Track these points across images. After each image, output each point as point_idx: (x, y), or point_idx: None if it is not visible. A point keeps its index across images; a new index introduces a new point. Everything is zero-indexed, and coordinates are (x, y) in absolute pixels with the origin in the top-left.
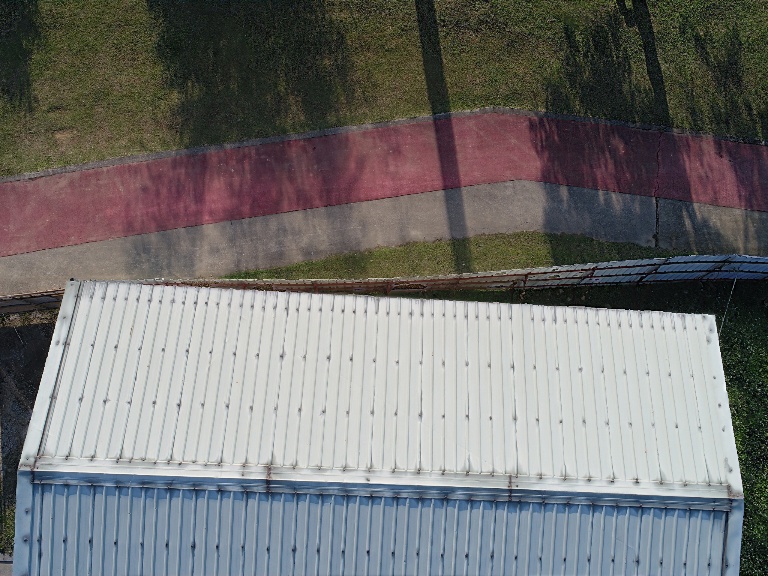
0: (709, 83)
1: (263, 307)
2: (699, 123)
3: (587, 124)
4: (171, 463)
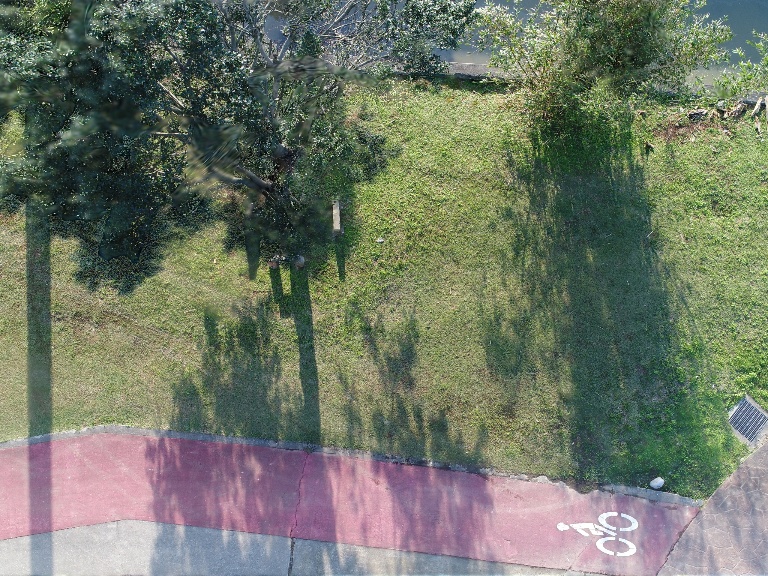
0: (374, 387)
1: None
2: (356, 439)
3: (218, 444)
4: None
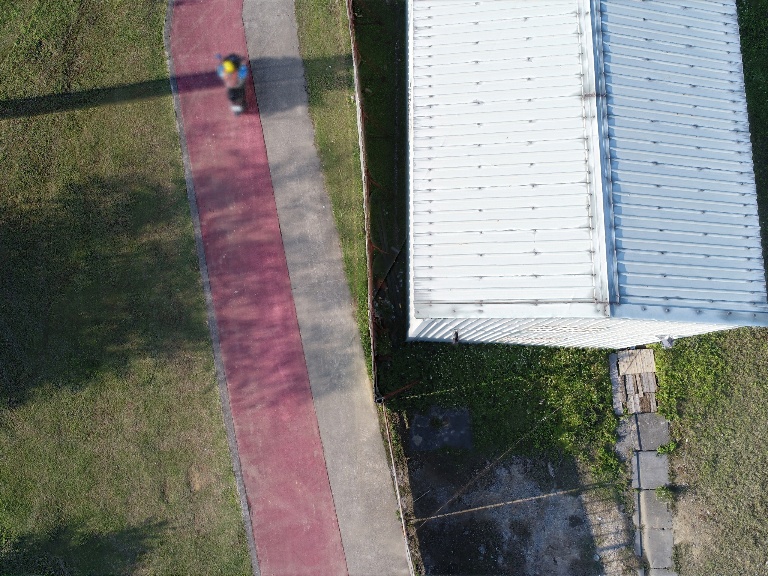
0: None
1: (430, 127)
2: None
3: None
4: (589, 181)
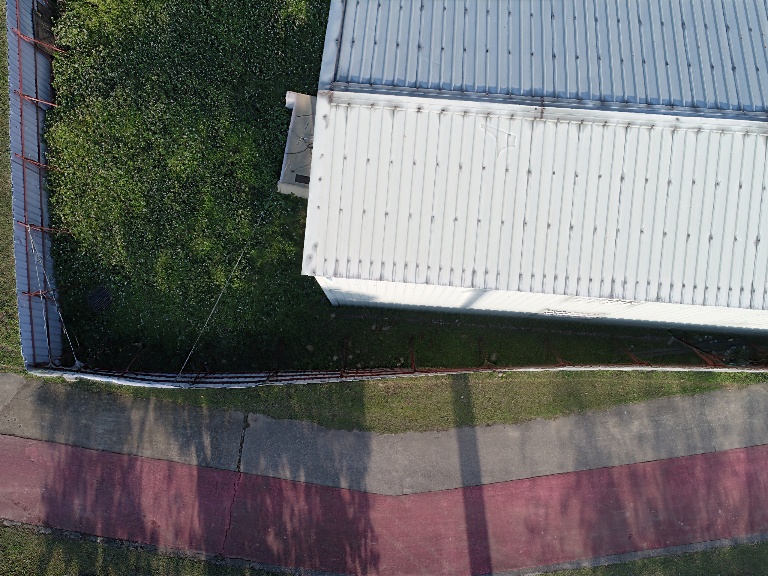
0: None
1: None
2: (172, 567)
3: (309, 567)
4: None
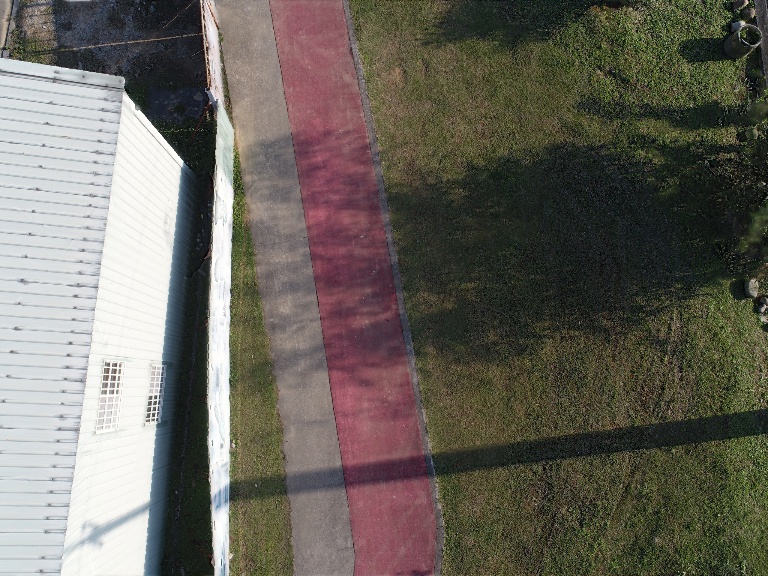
0: None
1: (82, 261)
2: None
3: None
4: None
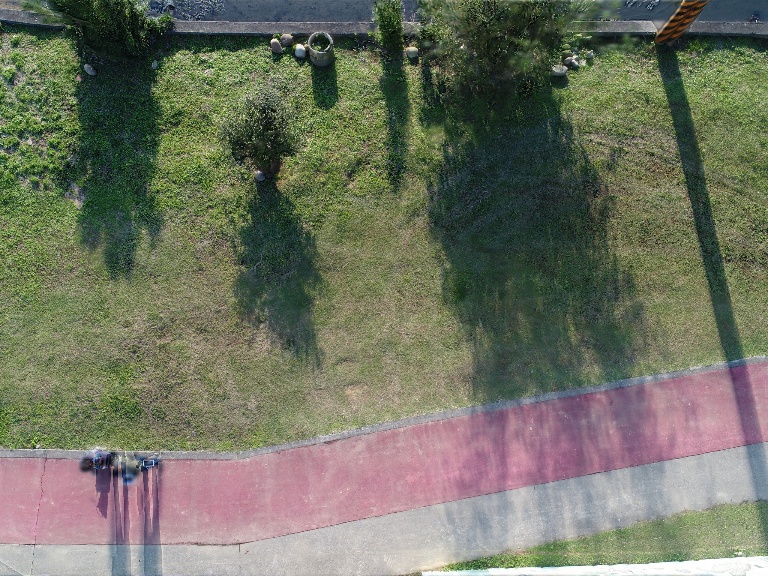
0: None
1: None
2: None
3: None
4: None
